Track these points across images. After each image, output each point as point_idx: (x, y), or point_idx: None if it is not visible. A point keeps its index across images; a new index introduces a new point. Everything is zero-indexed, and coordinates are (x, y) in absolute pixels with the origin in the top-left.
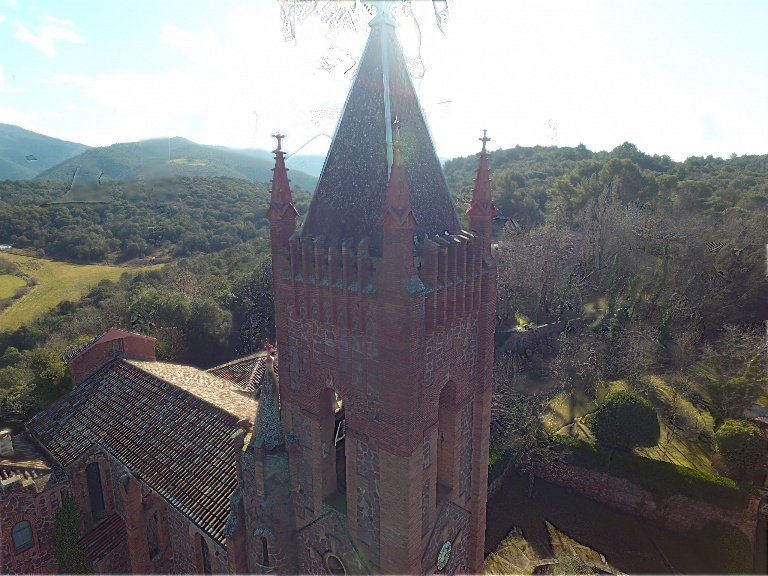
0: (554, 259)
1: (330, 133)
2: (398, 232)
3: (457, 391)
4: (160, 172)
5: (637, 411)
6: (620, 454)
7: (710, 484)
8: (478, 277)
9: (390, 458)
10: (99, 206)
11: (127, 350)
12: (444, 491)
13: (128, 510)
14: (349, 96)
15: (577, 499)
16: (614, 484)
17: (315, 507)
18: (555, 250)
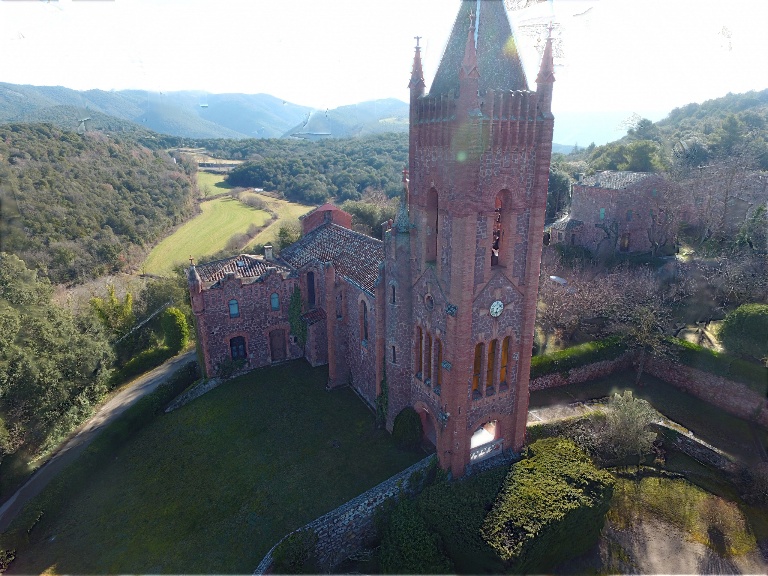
0: (737, 189)
1: None
2: (467, 80)
3: (513, 199)
4: (369, 113)
5: (767, 321)
6: (743, 362)
7: None
8: (533, 122)
9: (457, 221)
10: (324, 137)
11: (334, 219)
12: (500, 267)
13: (327, 283)
14: (460, 8)
15: (688, 397)
16: (730, 388)
17: (422, 267)
18: (740, 179)
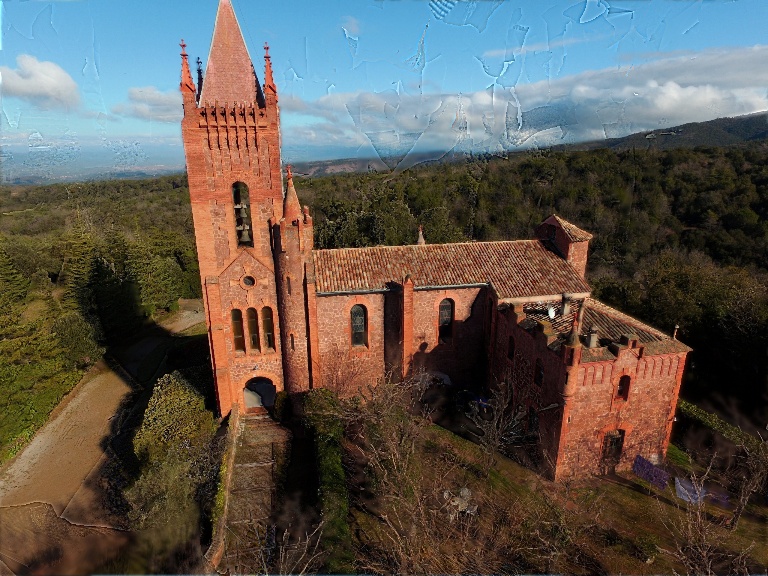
0: None
1: None
2: None
3: None
4: None
5: None
6: None
7: None
8: None
9: None
10: None
11: None
12: None
13: None
14: None
15: None
16: None
17: None
18: None
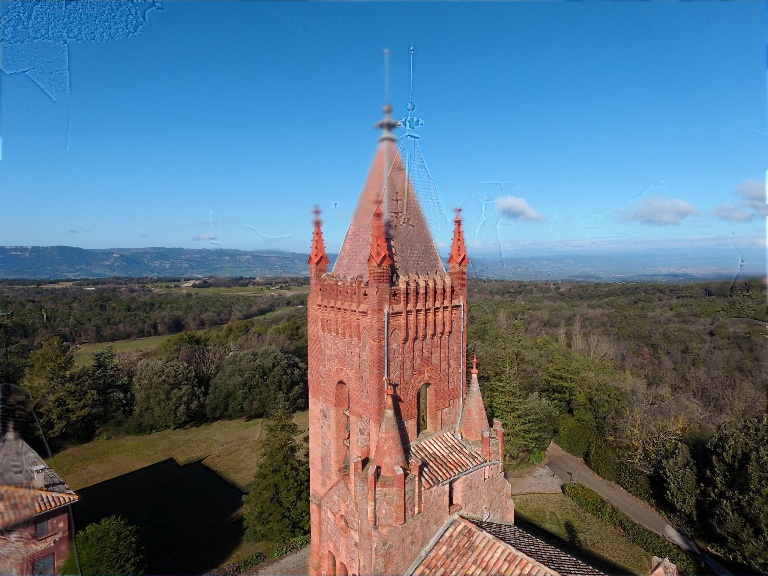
0: None
1: (410, 1)
2: None
3: None
4: None
5: None
6: None
7: None
8: None
9: None
10: None
11: None
12: None
13: None
14: None
15: None
16: None
17: None
18: None
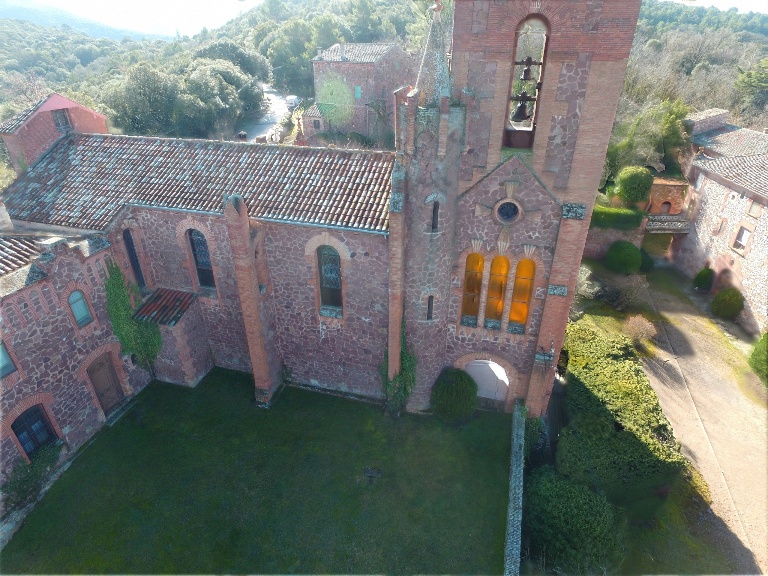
0: None
1: None
2: None
3: None
4: None
5: None
6: None
7: (616, 215)
8: None
9: (605, 67)
10: None
11: (77, 126)
12: None
13: (240, 235)
14: None
15: None
16: None
17: (489, 160)
18: None
